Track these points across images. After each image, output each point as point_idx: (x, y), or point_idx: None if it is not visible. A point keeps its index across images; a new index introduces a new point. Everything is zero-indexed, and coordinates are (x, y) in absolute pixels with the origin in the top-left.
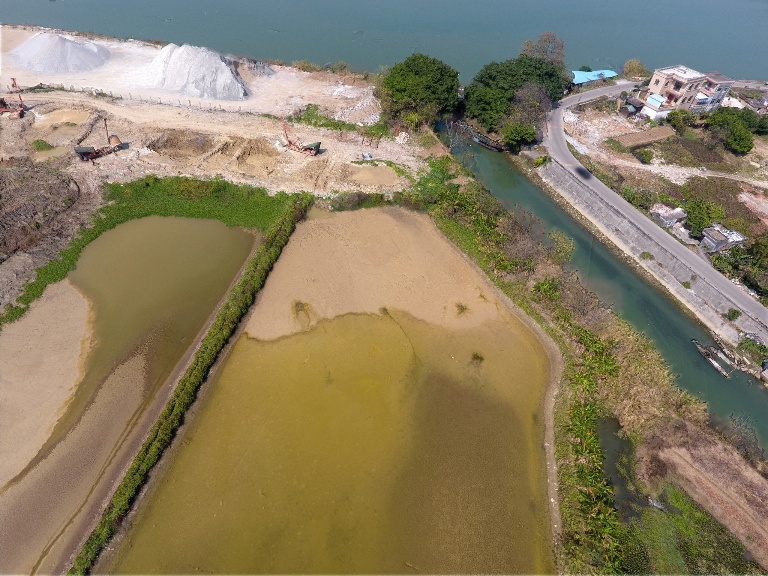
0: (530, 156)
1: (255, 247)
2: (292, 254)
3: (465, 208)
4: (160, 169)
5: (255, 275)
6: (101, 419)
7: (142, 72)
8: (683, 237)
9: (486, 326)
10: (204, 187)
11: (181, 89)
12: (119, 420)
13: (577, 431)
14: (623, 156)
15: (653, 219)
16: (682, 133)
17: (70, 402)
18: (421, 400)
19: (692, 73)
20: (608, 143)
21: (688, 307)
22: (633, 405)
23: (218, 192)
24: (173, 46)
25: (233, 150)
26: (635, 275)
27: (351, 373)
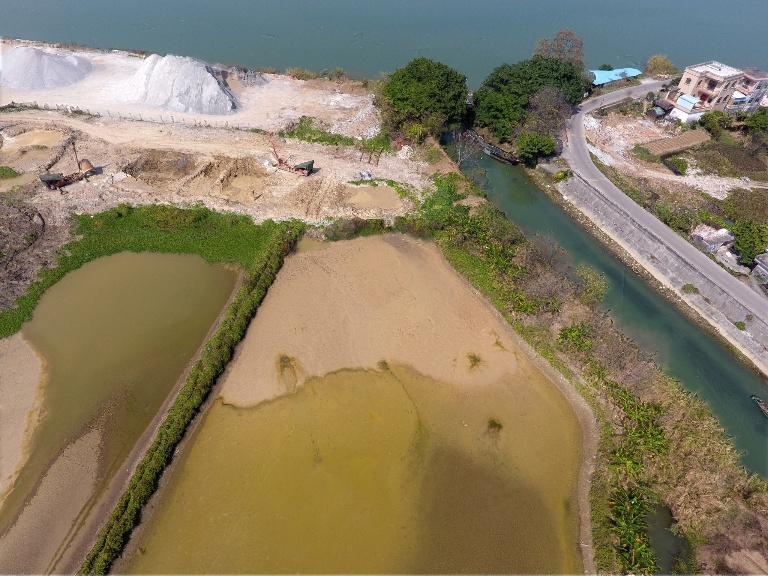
0: (549, 170)
1: (237, 287)
2: (279, 295)
3: (477, 235)
4: (135, 197)
5: (234, 324)
6: (42, 518)
7: (124, 86)
8: (730, 264)
9: (504, 382)
10: (182, 217)
11: (164, 103)
12: (63, 519)
13: (623, 535)
14: (653, 166)
15: (694, 243)
16: (718, 137)
17: (7, 495)
18: (428, 484)
19: (728, 70)
20: (635, 151)
21: (743, 353)
22: (689, 493)
23: (198, 222)
24: (156, 57)
25: (218, 171)
26: (677, 312)
27: (344, 449)
